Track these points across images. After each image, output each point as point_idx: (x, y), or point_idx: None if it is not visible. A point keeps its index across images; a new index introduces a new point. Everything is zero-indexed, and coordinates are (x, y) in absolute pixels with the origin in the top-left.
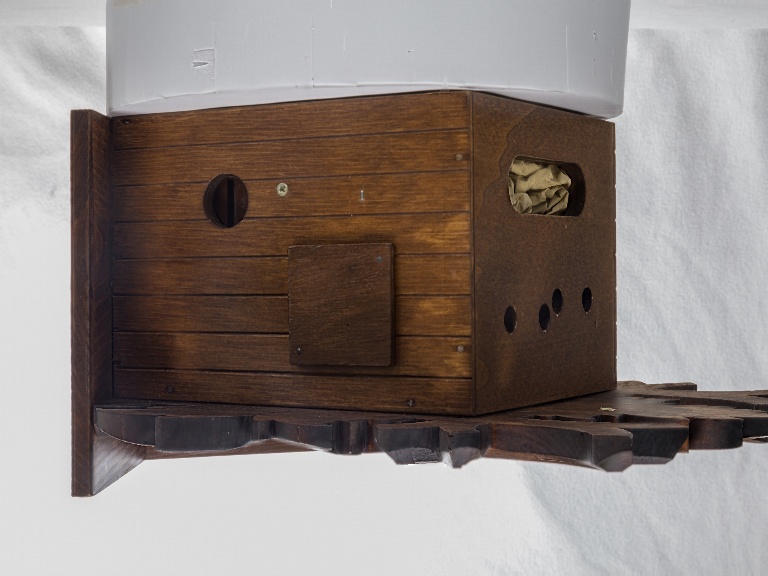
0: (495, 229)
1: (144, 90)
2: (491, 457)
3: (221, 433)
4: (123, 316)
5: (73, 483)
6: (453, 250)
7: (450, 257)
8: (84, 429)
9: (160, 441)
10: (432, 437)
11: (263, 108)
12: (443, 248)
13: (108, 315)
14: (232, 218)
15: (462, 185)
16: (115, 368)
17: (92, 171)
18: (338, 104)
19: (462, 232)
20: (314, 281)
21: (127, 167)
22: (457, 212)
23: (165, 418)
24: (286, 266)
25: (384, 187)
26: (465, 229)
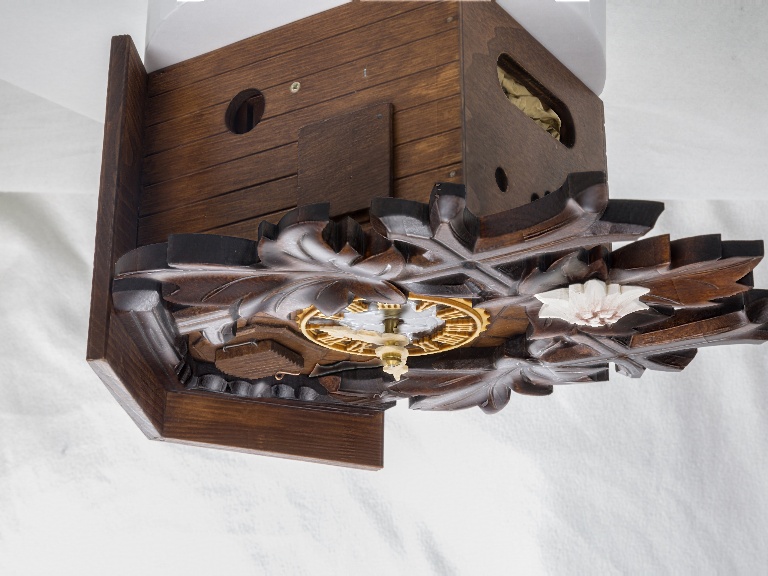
0: (485, 93)
1: None
2: (481, 250)
3: (229, 250)
4: (147, 233)
5: (88, 347)
6: (445, 95)
7: (442, 101)
8: (103, 298)
9: (171, 254)
10: (423, 211)
11: (281, 28)
12: (436, 95)
13: (133, 230)
14: None
15: (452, 40)
16: None
17: (127, 84)
18: (345, 7)
19: (453, 78)
20: (321, 150)
21: (159, 108)
22: (448, 63)
23: (177, 234)
24: (297, 149)
25: (384, 61)
26: (455, 75)
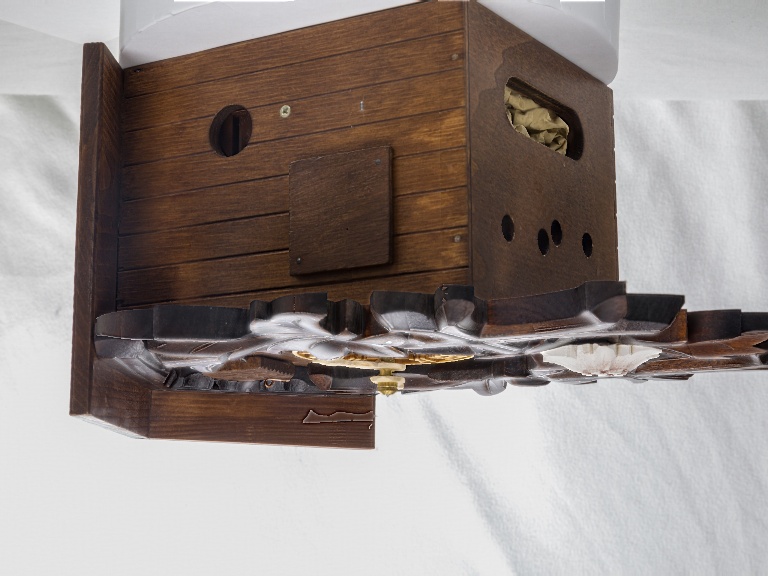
0: (491, 134)
1: (154, 13)
2: (488, 336)
3: (219, 323)
4: (128, 255)
5: (71, 401)
6: (449, 145)
7: (447, 152)
8: (84, 347)
9: (158, 329)
10: (427, 303)
11: (268, 39)
12: (440, 145)
13: (113, 252)
14: (237, 152)
15: (458, 83)
16: (119, 307)
17: (102, 100)
18: (339, 24)
19: (458, 127)
20: (314, 191)
21: (137, 112)
22: (453, 109)
23: (163, 306)
24: (288, 184)
25: (383, 95)
26: (461, 123)
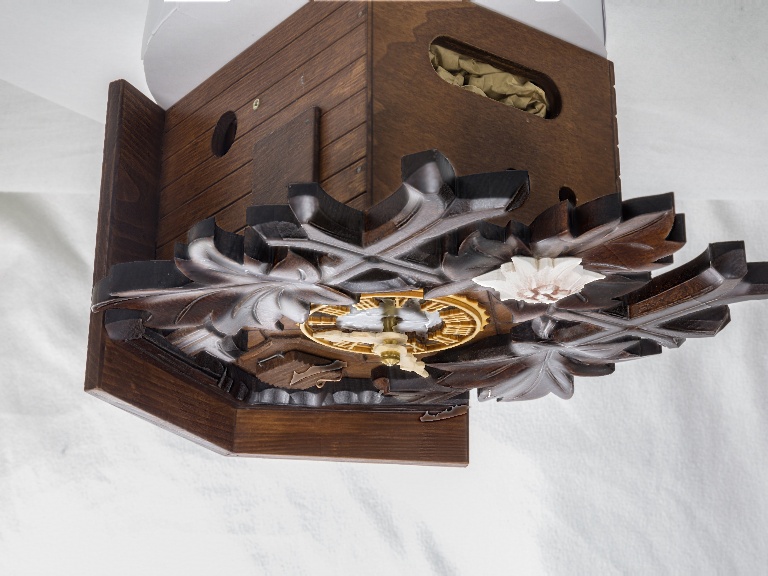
0: (407, 81)
1: None
2: (368, 244)
3: (162, 274)
4: None
5: (86, 379)
6: (355, 91)
7: (354, 97)
8: (97, 331)
9: (112, 285)
10: None
11: None
12: (349, 93)
13: None
14: None
15: (361, 35)
16: None
17: (121, 126)
18: (291, 18)
19: (361, 73)
20: (267, 162)
21: (171, 142)
22: (358, 59)
23: (116, 265)
24: None
25: (315, 66)
26: (363, 69)
